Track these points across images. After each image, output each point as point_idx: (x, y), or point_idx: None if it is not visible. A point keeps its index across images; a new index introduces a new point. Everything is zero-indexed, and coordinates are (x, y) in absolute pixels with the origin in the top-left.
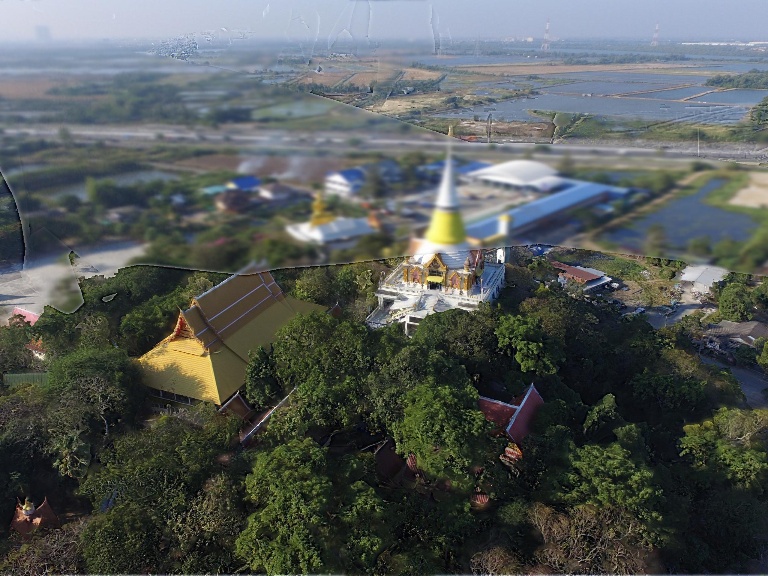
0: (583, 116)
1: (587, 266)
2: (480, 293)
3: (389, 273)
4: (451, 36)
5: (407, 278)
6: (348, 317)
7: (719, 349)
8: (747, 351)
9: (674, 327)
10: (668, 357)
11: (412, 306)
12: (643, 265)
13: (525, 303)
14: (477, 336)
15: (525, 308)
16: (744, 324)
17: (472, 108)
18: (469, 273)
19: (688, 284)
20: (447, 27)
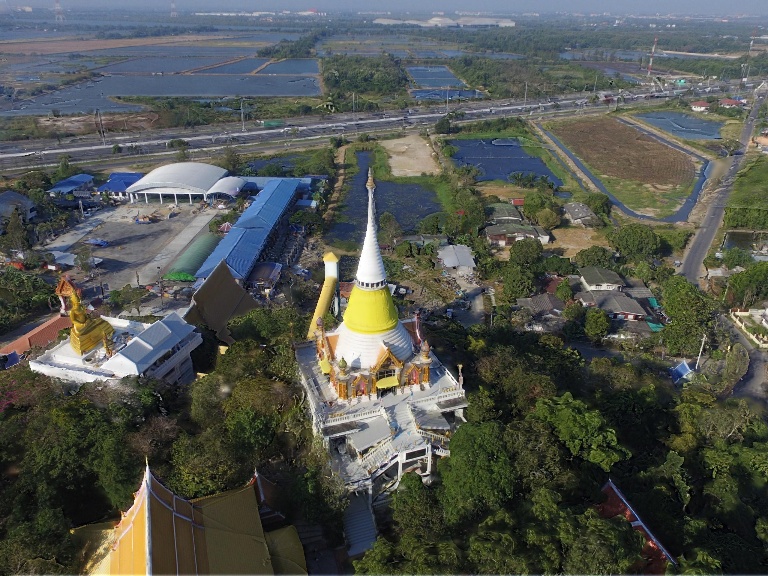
0: (750, 163)
1: (352, 276)
2: (438, 378)
3: (300, 393)
4: (11, 12)
5: (346, 394)
6: (323, 495)
7: (540, 330)
8: (574, 327)
9: (502, 322)
10: (601, 371)
11: (390, 435)
12: (397, 259)
13: (484, 370)
14: (554, 455)
15: (487, 376)
16: (538, 298)
17: (33, 99)
18: (431, 360)
19: (450, 269)
20: (2, 0)
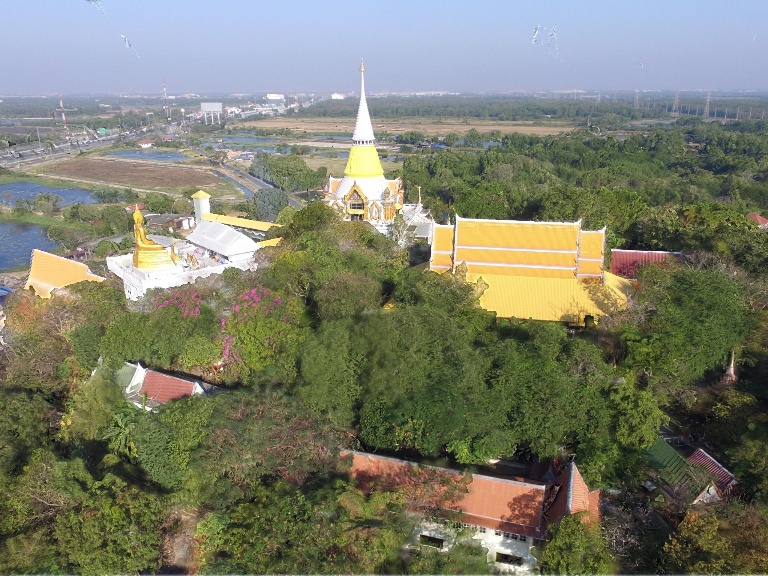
0: None
1: None
2: None
3: None
4: None
5: None
6: None
7: None
8: None
9: None
10: None
11: None
12: (104, 259)
13: None
14: None
15: None
16: None
17: None
18: None
19: None
20: None
